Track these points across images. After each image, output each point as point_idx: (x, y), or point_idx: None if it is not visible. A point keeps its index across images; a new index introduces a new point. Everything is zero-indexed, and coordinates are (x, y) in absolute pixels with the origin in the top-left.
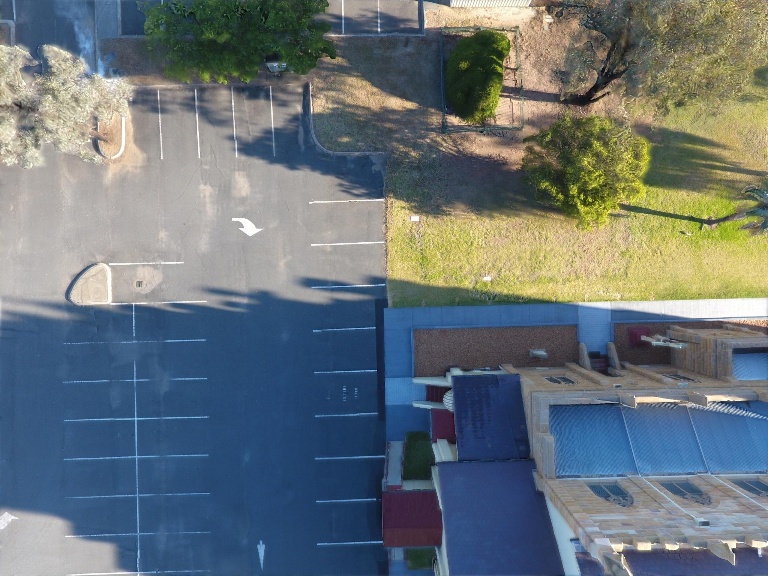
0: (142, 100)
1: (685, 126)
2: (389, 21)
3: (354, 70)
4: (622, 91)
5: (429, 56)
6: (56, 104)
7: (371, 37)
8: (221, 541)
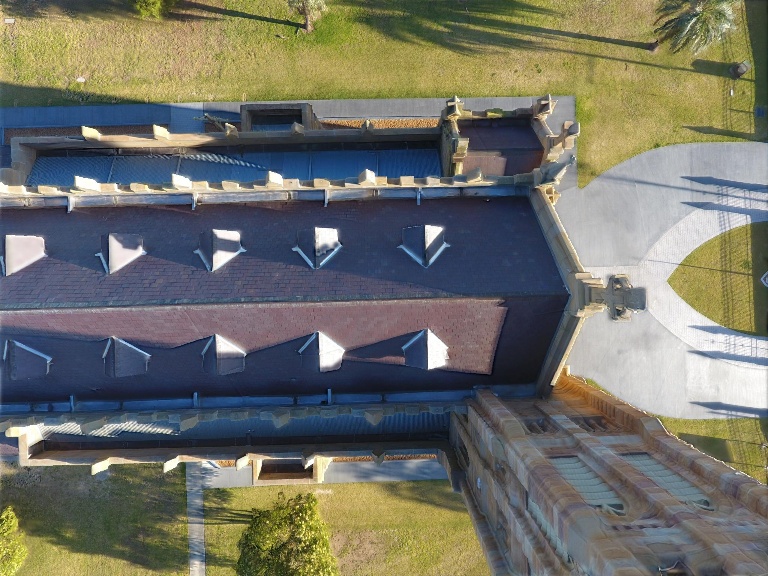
0: None
1: None
2: None
3: None
4: None
5: None
6: None
7: None
8: None
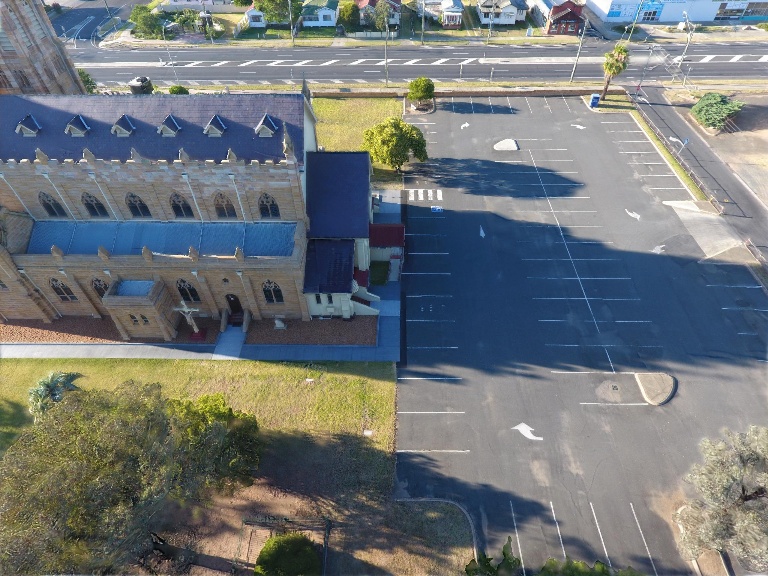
0: None
1: None
2: None
3: None
4: None
5: None
6: (727, 472)
7: None
8: (509, 238)
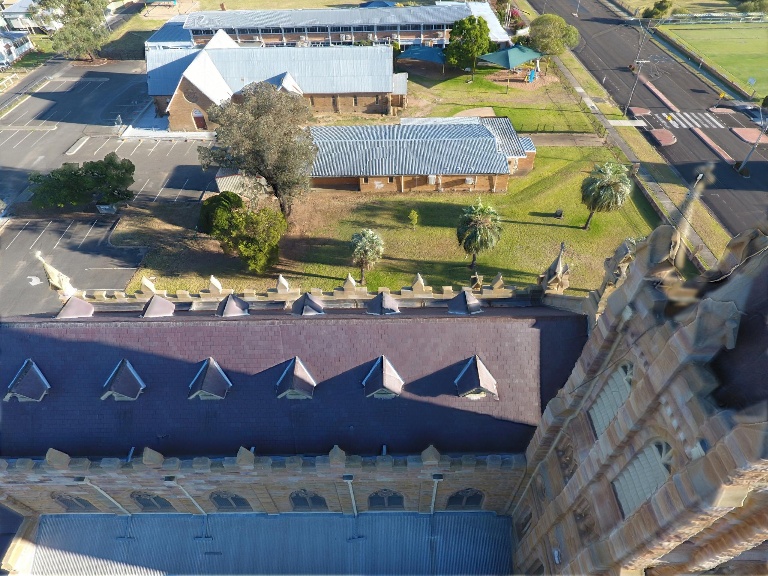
0: (16, 225)
1: (350, 239)
2: (183, 198)
3: (151, 214)
4: (243, 172)
5: (199, 210)
6: None
7: (169, 203)
8: None
